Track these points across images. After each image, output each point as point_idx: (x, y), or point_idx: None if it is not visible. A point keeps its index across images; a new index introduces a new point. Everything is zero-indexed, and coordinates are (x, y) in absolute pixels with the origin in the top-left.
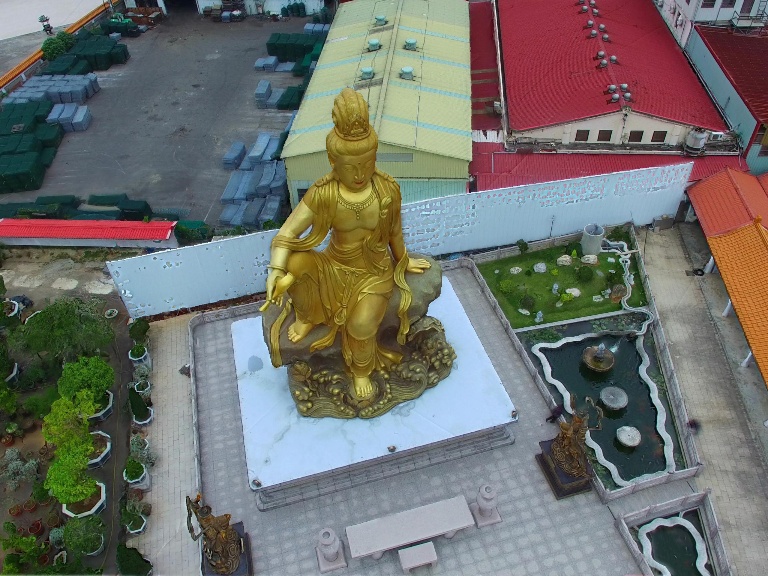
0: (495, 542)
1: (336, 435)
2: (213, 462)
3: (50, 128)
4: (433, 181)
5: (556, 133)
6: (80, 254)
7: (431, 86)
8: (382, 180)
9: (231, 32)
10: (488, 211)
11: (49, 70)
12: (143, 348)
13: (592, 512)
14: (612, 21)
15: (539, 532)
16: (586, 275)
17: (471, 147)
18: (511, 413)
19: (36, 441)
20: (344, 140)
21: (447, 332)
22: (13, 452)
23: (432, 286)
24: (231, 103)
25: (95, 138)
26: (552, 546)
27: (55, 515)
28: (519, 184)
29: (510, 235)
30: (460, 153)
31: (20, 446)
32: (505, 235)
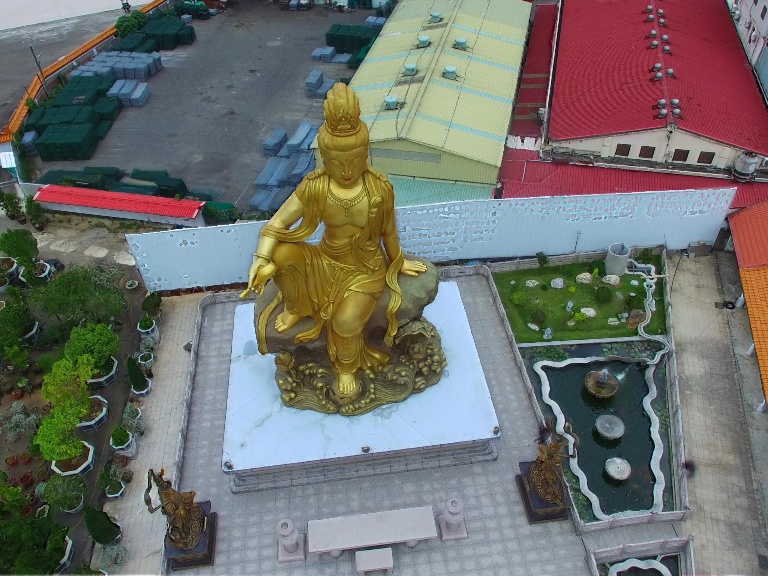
0: (457, 558)
1: (314, 428)
2: (198, 439)
3: (109, 102)
4: (459, 184)
5: (595, 145)
6: (115, 225)
7: (473, 87)
8: (374, 178)
9: (296, 20)
10: (509, 220)
11: (118, 46)
12: (151, 321)
13: (564, 542)
14: (678, 32)
15: (504, 554)
16: (604, 296)
17: (502, 153)
18: (493, 429)
19: (42, 398)
20: (332, 135)
21: (445, 338)
22: (19, 405)
23: (425, 290)
24: (283, 90)
25: (149, 115)
26: (515, 571)
27: (45, 470)
28: (546, 195)
29: (532, 246)
30: (489, 158)
31: (27, 400)
32: (527, 246)
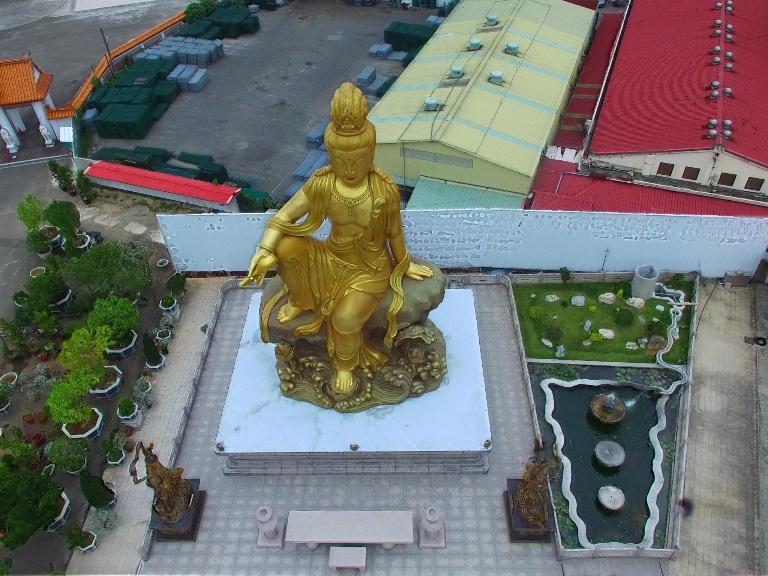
0: (431, 566)
1: (308, 420)
2: (200, 418)
3: (168, 85)
4: (490, 191)
5: (636, 162)
6: (157, 204)
7: (518, 94)
8: (380, 180)
9: (359, 16)
10: (535, 231)
11: (184, 32)
12: (172, 299)
13: (542, 565)
14: (746, 50)
15: (479, 569)
16: (624, 318)
17: (536, 163)
18: (485, 442)
19: None
20: (336, 134)
21: (451, 346)
22: (42, 367)
23: (428, 295)
24: (335, 84)
25: (205, 100)
26: None
27: (56, 430)
28: (577, 209)
29: (558, 261)
30: (522, 167)
31: (52, 363)
32: (552, 260)
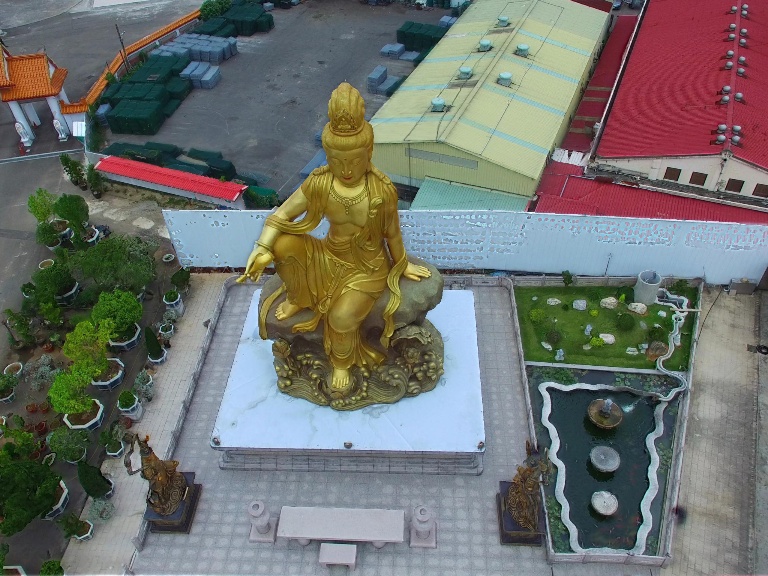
0: (421, 566)
1: (304, 417)
2: (199, 412)
3: (181, 82)
4: (495, 193)
5: (643, 166)
6: (165, 199)
7: (526, 96)
8: (377, 180)
9: (373, 15)
10: (538, 234)
11: (199, 29)
12: (176, 294)
13: (532, 568)
14: (760, 54)
15: (469, 570)
16: (625, 323)
17: (542, 165)
18: (478, 443)
19: None
20: (333, 134)
21: (450, 347)
22: (47, 358)
23: (425, 296)
24: None
25: (216, 97)
26: None
27: (58, 421)
28: (581, 213)
29: (561, 264)
30: (527, 169)
31: (57, 354)
32: (555, 263)
